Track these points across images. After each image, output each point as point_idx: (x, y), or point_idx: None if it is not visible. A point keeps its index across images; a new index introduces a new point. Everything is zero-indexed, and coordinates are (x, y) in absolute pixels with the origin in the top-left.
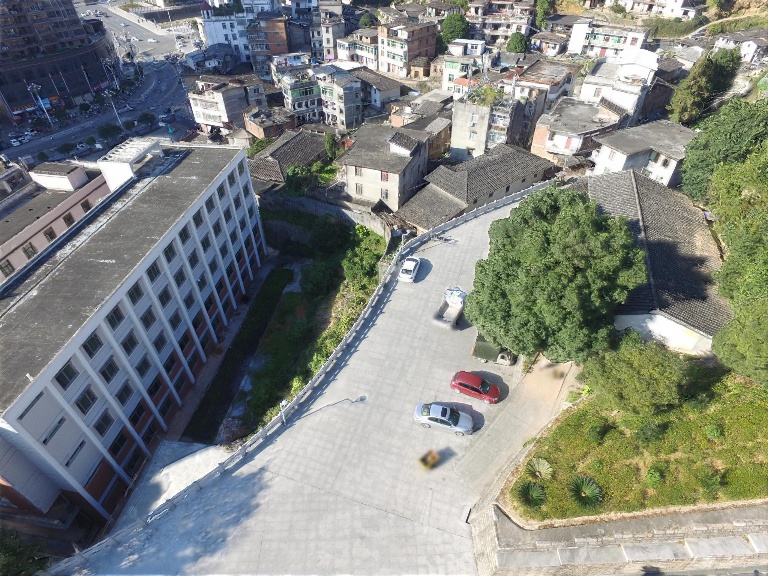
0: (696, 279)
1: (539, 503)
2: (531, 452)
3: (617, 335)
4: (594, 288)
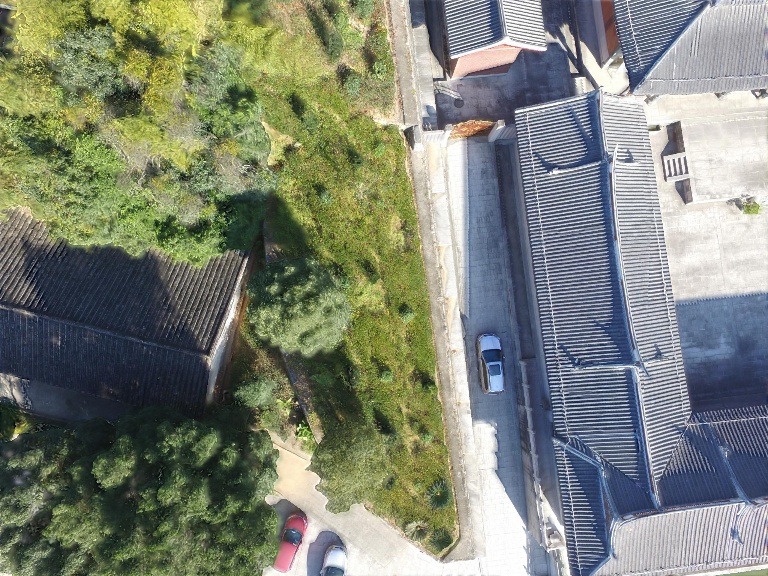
0: (125, 259)
1: (447, 534)
2: (390, 523)
3: (244, 410)
4: (233, 509)
